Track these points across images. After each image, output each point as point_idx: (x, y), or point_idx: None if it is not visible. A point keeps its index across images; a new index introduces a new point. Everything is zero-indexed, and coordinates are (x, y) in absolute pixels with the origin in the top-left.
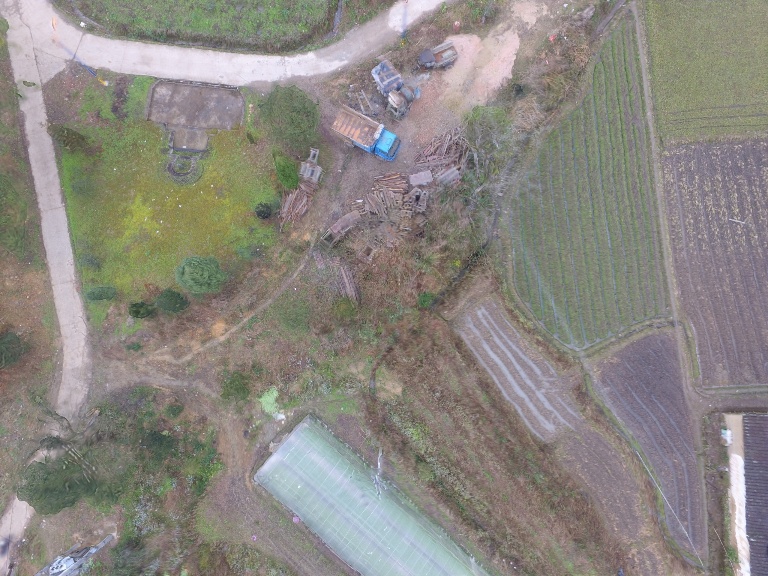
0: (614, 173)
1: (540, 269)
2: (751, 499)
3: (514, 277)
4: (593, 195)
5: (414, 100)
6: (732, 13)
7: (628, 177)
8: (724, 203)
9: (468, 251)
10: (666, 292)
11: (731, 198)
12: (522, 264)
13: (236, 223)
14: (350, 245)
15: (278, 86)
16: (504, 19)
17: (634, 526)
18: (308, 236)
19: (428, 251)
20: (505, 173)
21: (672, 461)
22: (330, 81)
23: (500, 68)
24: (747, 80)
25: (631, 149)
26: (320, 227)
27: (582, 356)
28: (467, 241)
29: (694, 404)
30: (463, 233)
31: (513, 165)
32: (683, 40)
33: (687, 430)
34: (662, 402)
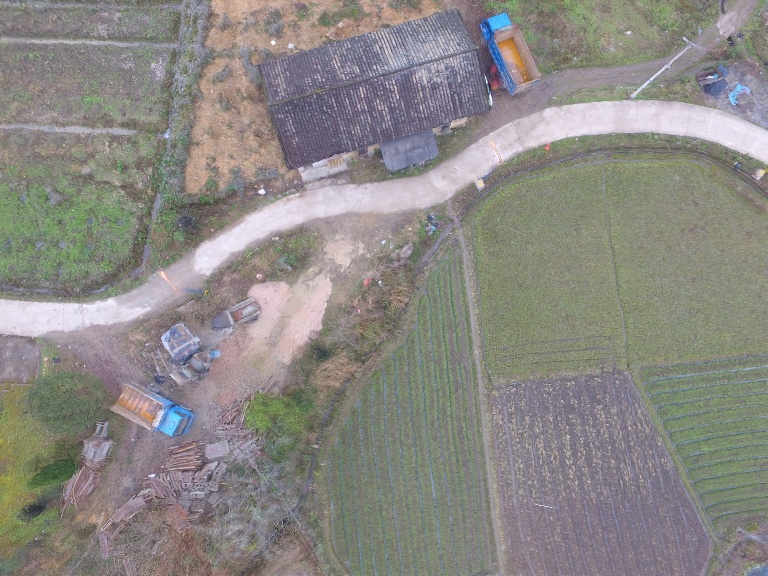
0: (439, 417)
1: (359, 525)
2: None
3: (332, 534)
4: (416, 442)
5: (214, 359)
6: (566, 238)
7: (454, 421)
8: (555, 445)
9: (272, 521)
10: (493, 546)
11: (563, 440)
12: (340, 520)
13: (14, 508)
14: (138, 529)
15: (41, 381)
16: (315, 262)
17: None
18: (93, 519)
19: (216, 542)
20: (320, 424)
21: None
22: (130, 332)
23: (307, 320)
24: (581, 311)
25: (457, 391)
26: (108, 507)
27: None
28: (264, 522)
29: None
30: (258, 515)
31: (329, 414)
32: (514, 269)
33: None
34: None
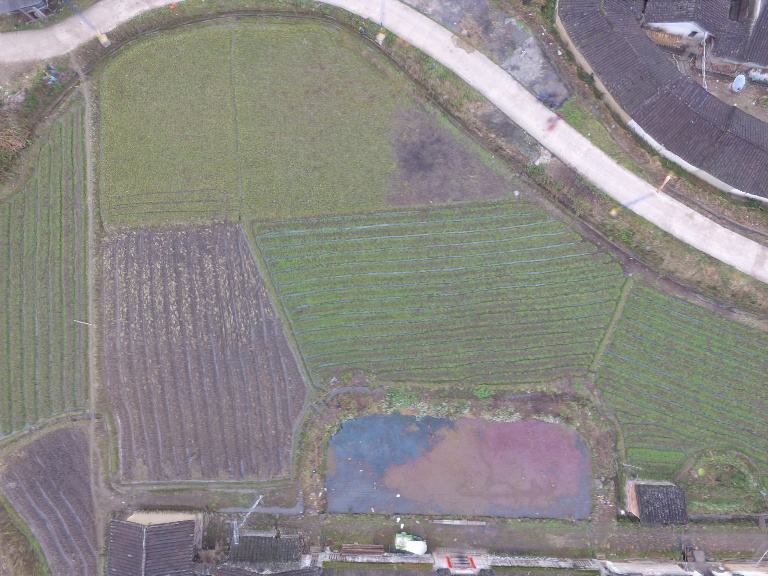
0: (48, 259)
1: None
2: None
3: None
4: (23, 281)
5: None
6: (190, 95)
7: (62, 263)
8: (161, 291)
9: None
10: (88, 383)
11: (169, 286)
12: None
13: None
14: None
15: None
16: None
17: None
18: None
19: None
20: None
21: None
22: None
23: None
24: (198, 164)
25: (67, 234)
26: None
27: None
28: None
29: (102, 501)
30: None
31: None
32: (136, 123)
33: (89, 529)
34: (67, 499)
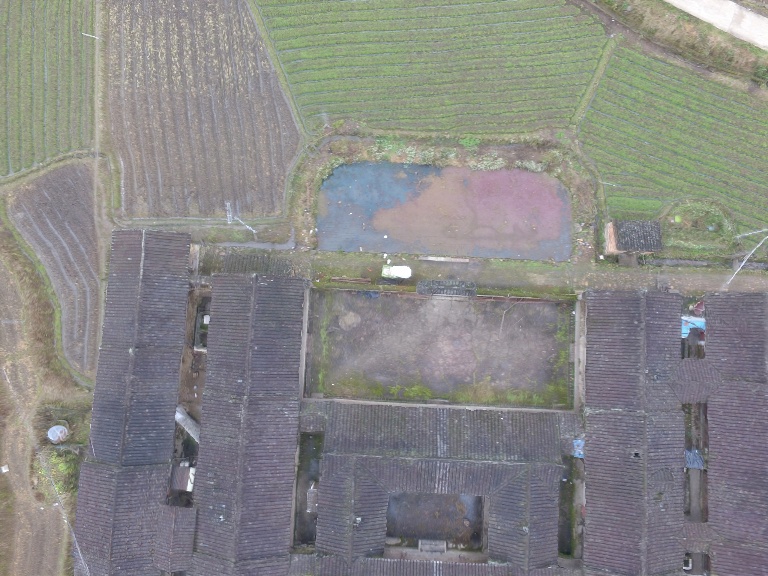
0: (58, 13)
1: None
2: (107, 310)
3: None
4: (34, 33)
5: None
6: None
7: (70, 17)
8: (163, 44)
9: None
10: (93, 126)
11: (171, 40)
12: None
13: None
14: None
15: None
16: None
17: (13, 340)
18: None
19: None
20: None
21: (75, 284)
22: None
23: None
24: None
25: None
26: None
27: (2, 183)
28: None
29: (104, 232)
30: None
31: None
32: None
33: (92, 255)
34: (72, 228)
